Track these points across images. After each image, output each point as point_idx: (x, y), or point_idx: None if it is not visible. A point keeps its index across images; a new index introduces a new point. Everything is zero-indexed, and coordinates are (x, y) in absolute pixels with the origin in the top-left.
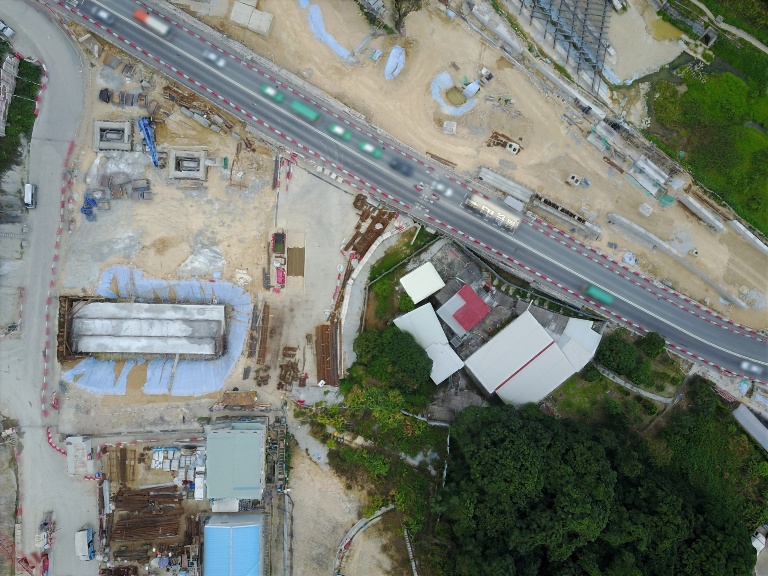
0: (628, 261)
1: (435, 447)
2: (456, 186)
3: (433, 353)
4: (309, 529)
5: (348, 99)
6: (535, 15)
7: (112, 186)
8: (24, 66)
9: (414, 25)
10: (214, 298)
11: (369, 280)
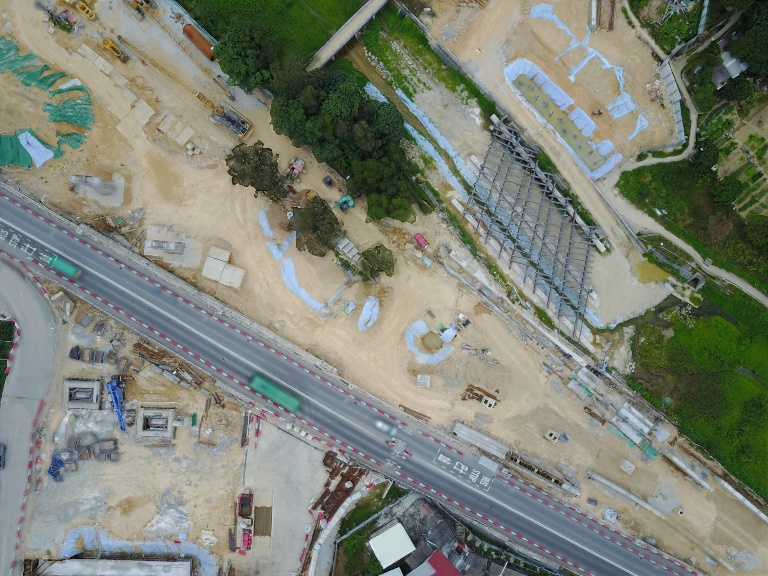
0: (609, 518)
1: None
2: (429, 441)
3: None
4: None
5: (320, 351)
6: (514, 260)
7: (79, 448)
8: None
9: None
10: (181, 552)
11: (339, 533)
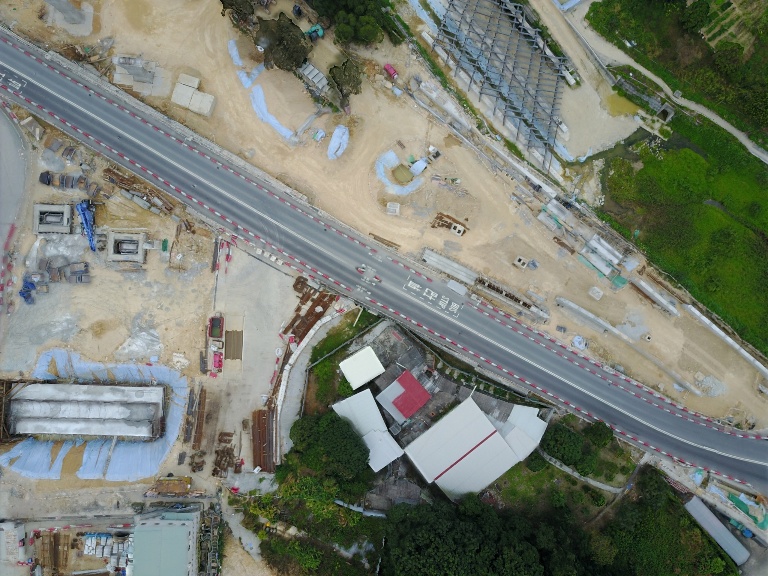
0: (578, 345)
1: (371, 538)
2: (399, 268)
3: (372, 440)
4: None
5: (290, 179)
6: (484, 91)
7: (50, 270)
8: None
9: (359, 103)
10: (153, 379)
11: (310, 362)
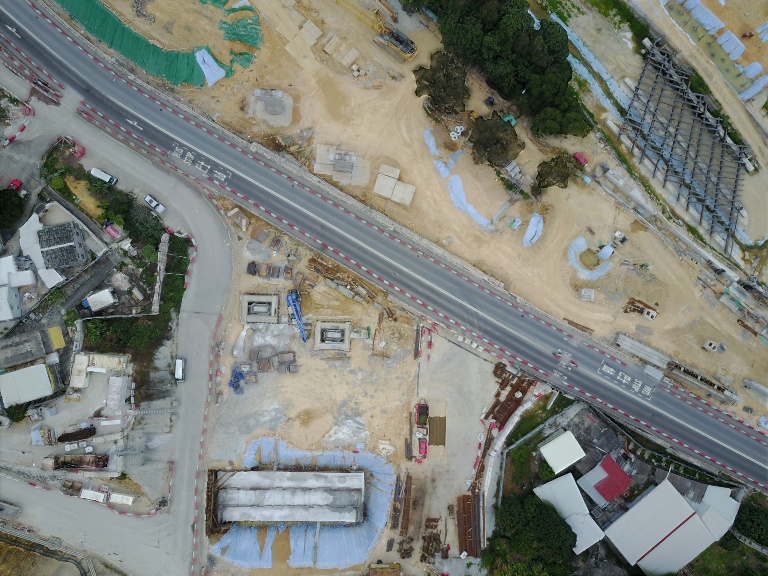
0: (764, 425)
1: None
2: (593, 352)
3: (574, 523)
4: None
5: (487, 266)
6: (668, 178)
7: (260, 360)
8: (174, 240)
9: (549, 190)
10: (354, 464)
11: (505, 444)
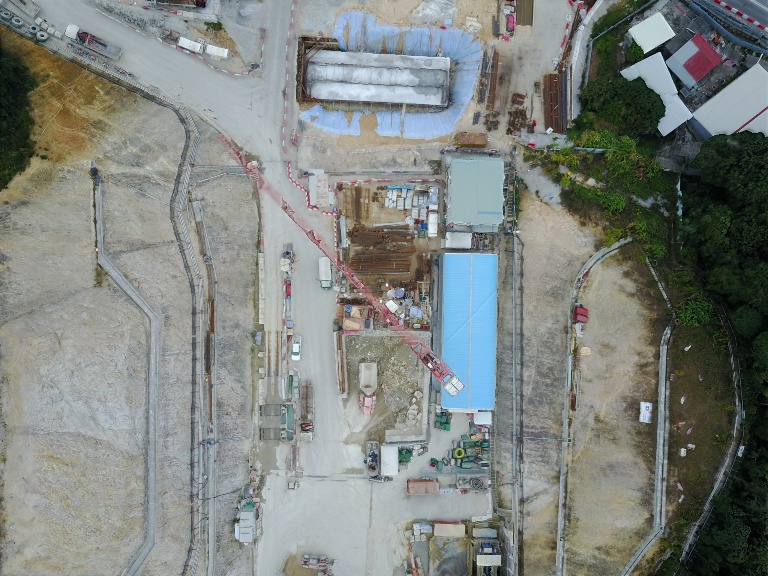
0: None
1: (665, 193)
2: None
3: None
4: (542, 265)
5: None
6: None
7: None
8: None
9: None
10: (439, 51)
11: (591, 38)
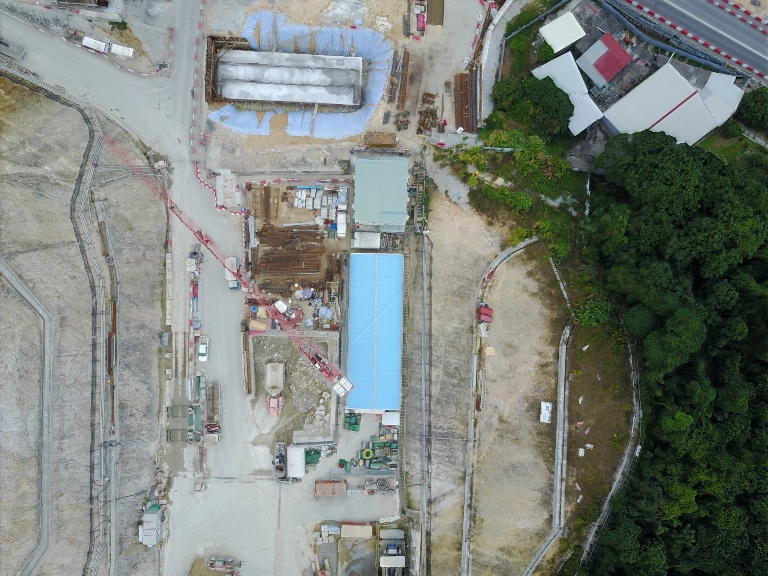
0: None
1: (574, 193)
2: None
3: (572, 103)
4: (449, 265)
5: None
6: None
7: None
8: None
9: None
10: (352, 51)
11: (505, 37)
